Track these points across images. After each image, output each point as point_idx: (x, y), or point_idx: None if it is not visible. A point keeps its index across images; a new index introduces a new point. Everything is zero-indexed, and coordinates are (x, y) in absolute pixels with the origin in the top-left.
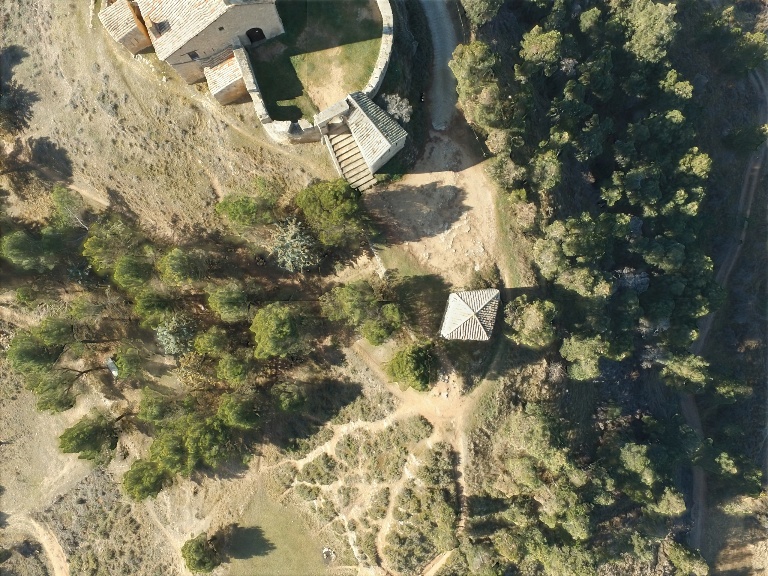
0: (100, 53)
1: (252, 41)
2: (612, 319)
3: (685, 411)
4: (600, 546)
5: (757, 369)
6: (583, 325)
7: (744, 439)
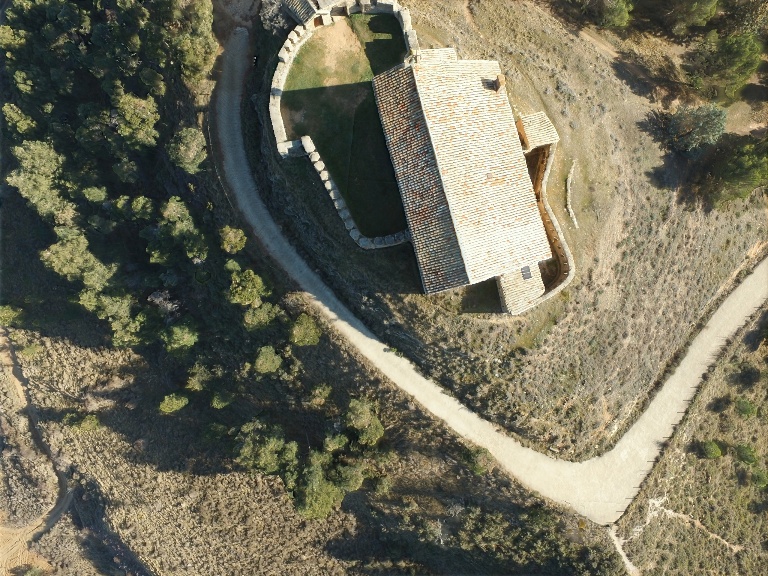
0: (567, 135)
1: None
2: None
3: None
4: None
5: None
6: None
7: None
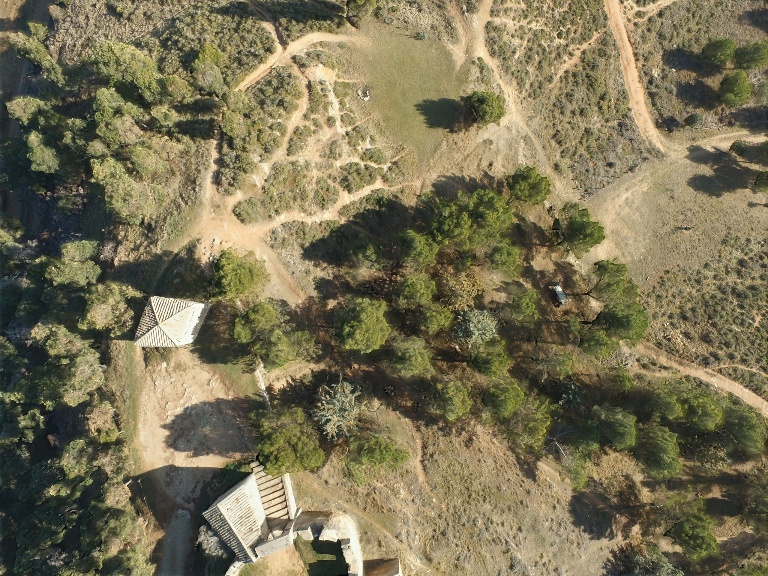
0: None
1: None
2: None
3: (19, 188)
4: None
5: None
6: (75, 295)
7: None
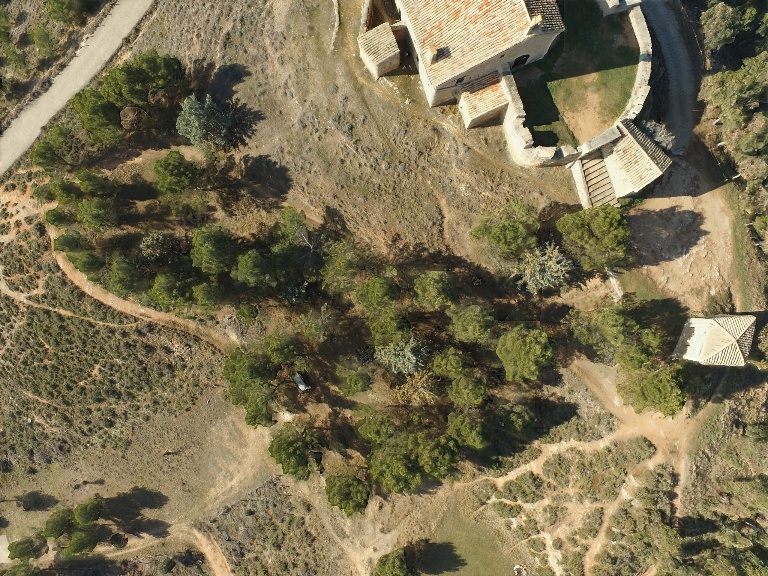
0: (340, 75)
1: (512, 67)
2: None
3: None
4: None
5: None
6: None
7: None
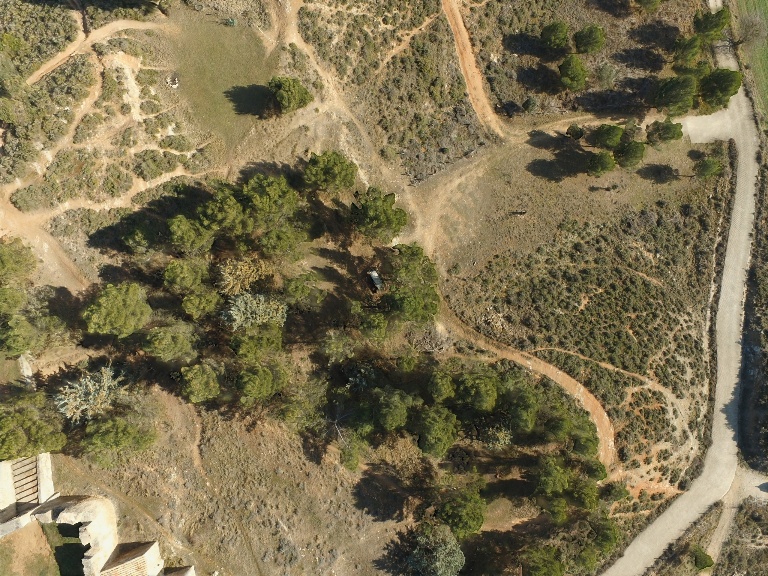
0: None
1: None
2: None
3: None
4: None
5: None
6: None
7: None
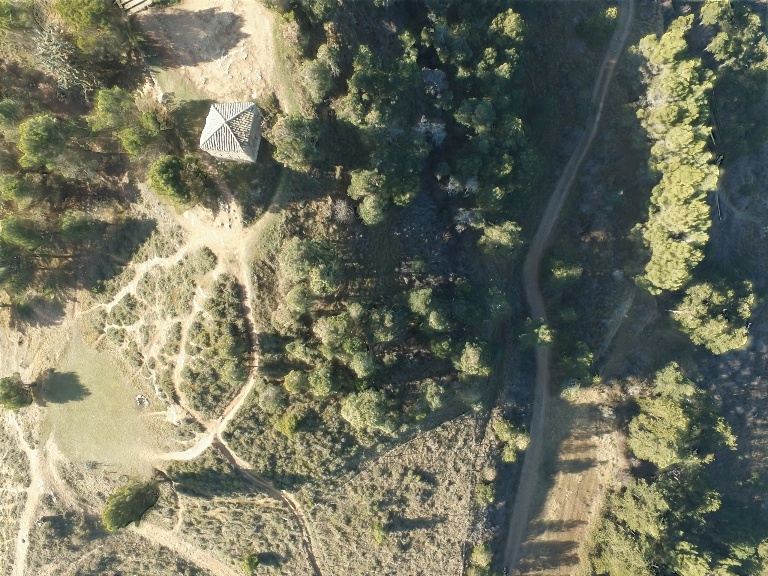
0: None
1: None
2: (400, 161)
3: (530, 299)
4: (411, 405)
5: (604, 261)
6: None
7: (586, 328)
